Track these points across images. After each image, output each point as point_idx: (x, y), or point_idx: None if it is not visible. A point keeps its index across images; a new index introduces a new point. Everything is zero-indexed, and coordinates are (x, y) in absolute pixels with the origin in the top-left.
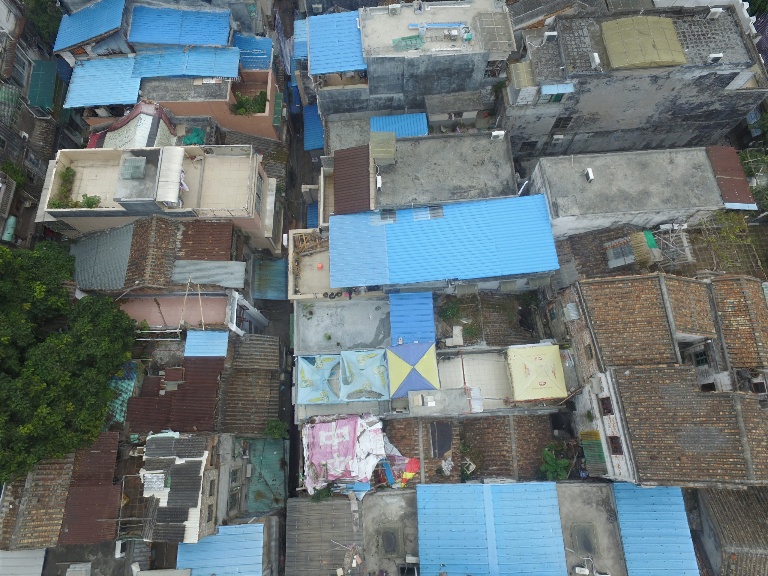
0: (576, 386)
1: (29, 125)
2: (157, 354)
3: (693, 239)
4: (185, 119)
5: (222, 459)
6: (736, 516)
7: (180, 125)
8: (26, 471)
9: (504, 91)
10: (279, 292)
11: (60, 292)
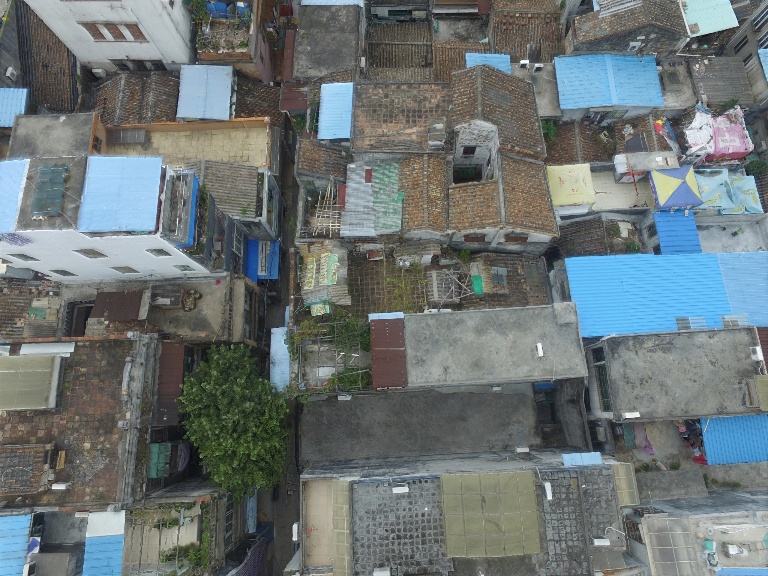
0: None
1: None
2: None
3: None
4: None
5: None
6: None
7: None
8: None
9: None
10: None
11: None
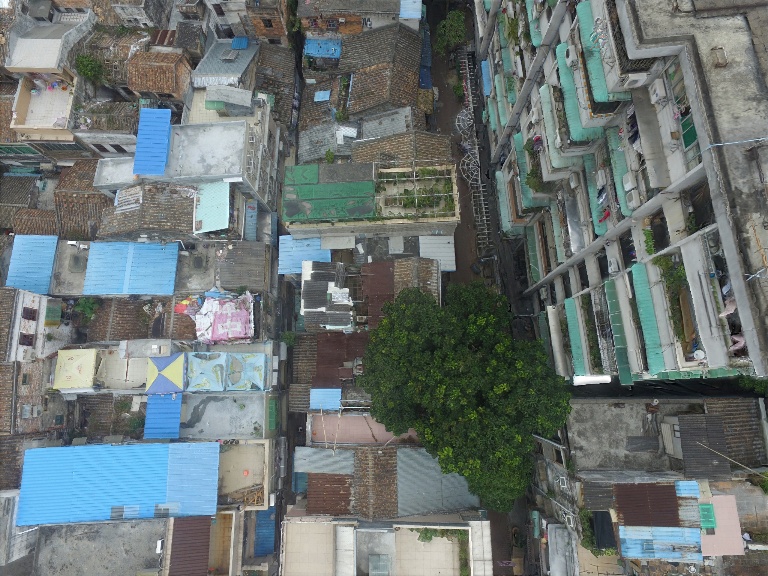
0: (54, 360)
1: None
2: None
3: None
4: None
5: None
6: None
7: None
8: None
9: None
10: None
11: None
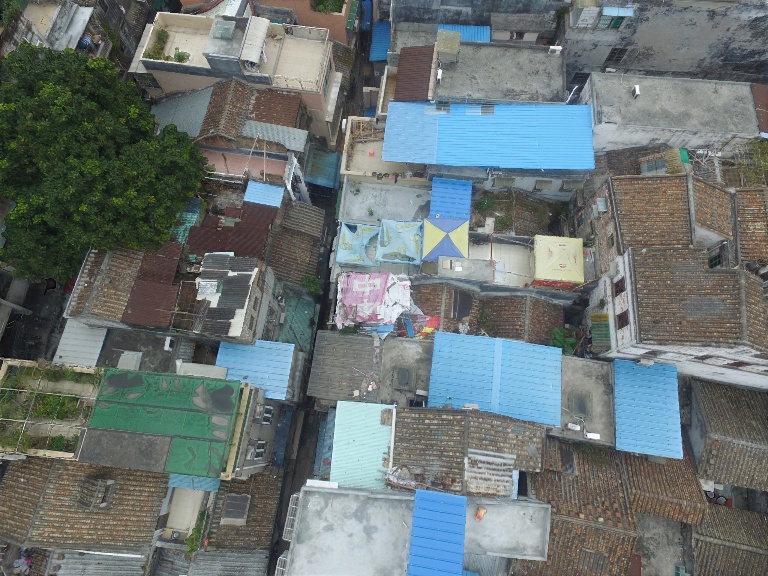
0: None
1: (126, 3)
2: (218, 201)
3: (725, 170)
4: (268, 9)
5: (266, 287)
6: (725, 413)
7: (263, 15)
8: (109, 244)
9: (566, 16)
10: (328, 180)
11: (148, 120)
